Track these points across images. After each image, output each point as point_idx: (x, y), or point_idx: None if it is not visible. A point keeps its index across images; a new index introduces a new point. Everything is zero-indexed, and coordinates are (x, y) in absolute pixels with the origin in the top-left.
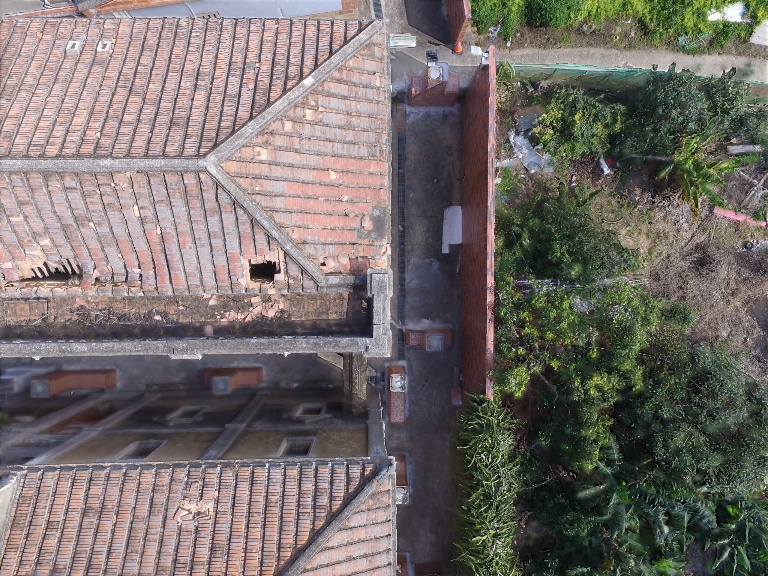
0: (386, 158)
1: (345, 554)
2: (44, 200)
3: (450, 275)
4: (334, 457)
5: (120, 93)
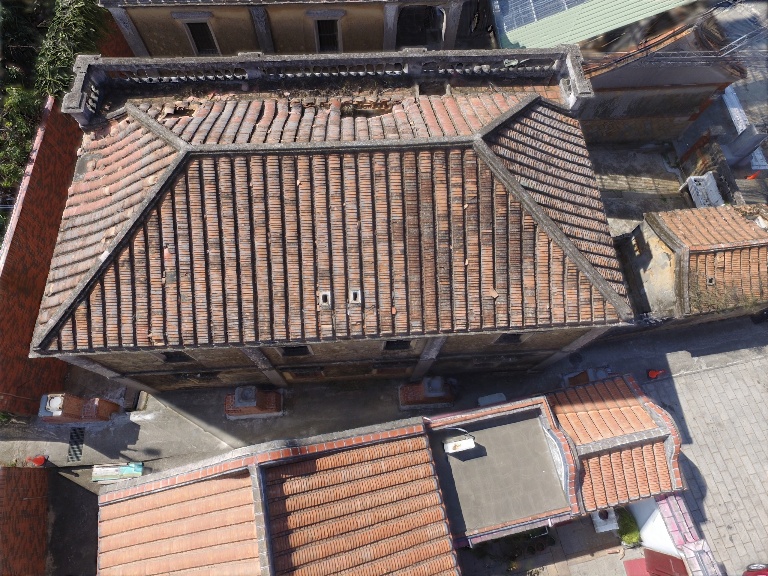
0: None
1: None
2: (346, 132)
3: None
4: (148, 6)
5: (292, 235)
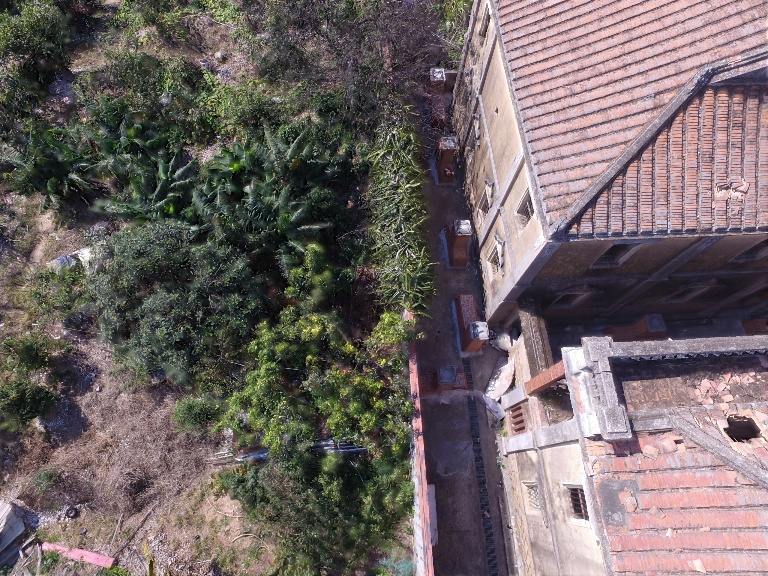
0: None
1: (586, 158)
2: None
3: None
4: None
5: None
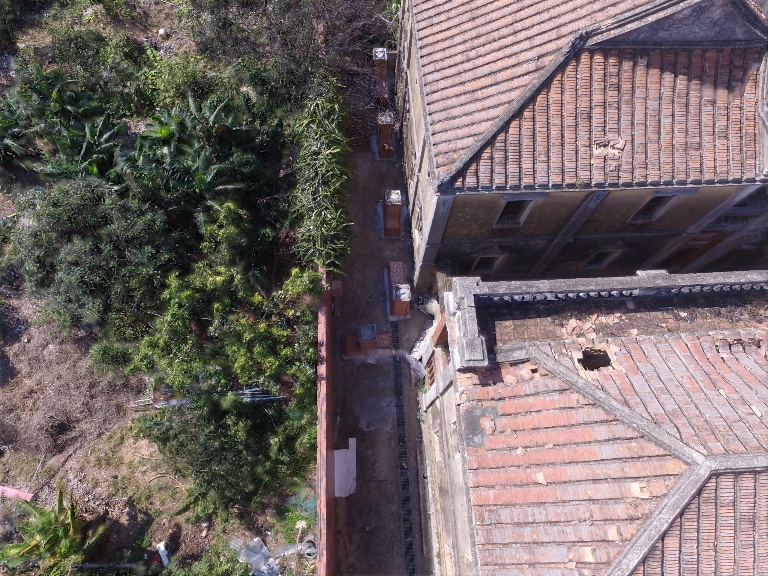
0: (474, 511)
1: (474, 117)
2: None
3: (346, 412)
4: None
5: None
